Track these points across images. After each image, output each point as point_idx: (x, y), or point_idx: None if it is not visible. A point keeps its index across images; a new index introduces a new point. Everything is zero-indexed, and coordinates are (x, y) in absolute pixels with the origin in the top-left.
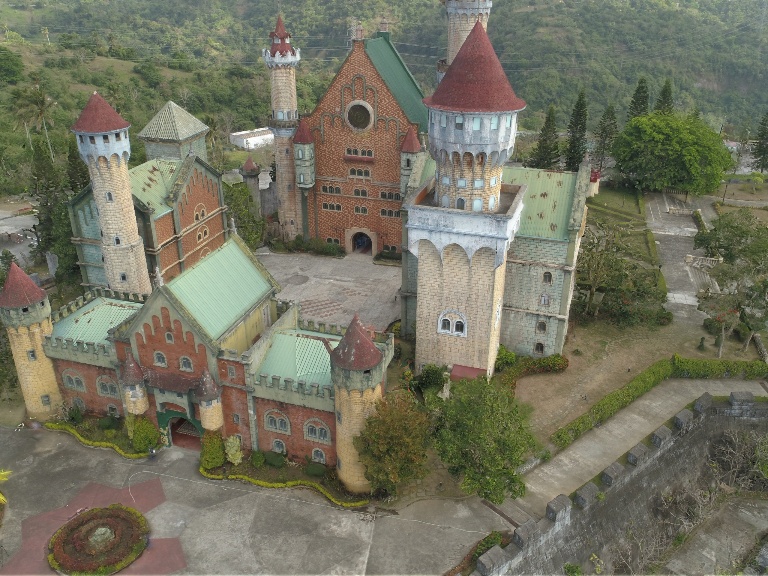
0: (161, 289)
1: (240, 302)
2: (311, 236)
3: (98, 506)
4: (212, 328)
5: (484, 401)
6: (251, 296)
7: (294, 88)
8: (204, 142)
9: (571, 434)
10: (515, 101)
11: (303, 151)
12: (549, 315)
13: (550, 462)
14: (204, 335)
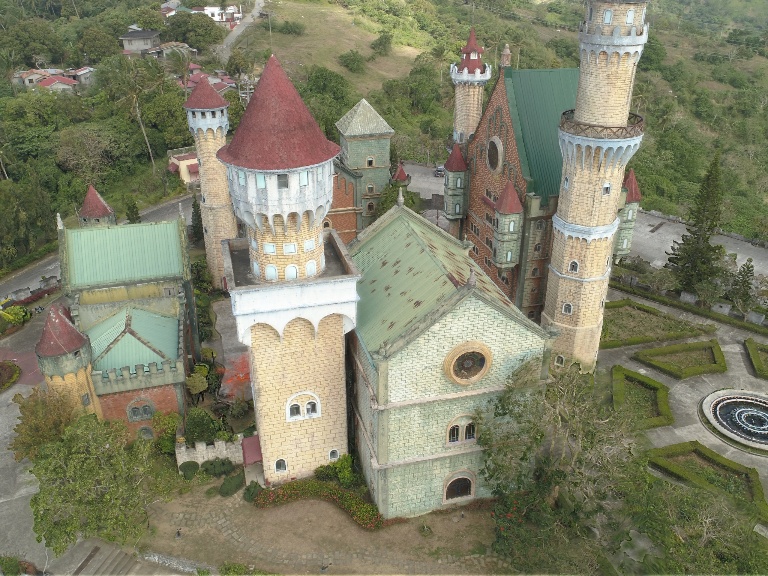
0: (58, 231)
1: (133, 271)
2: None
3: (21, 364)
4: (82, 277)
5: (76, 445)
6: (151, 271)
7: (474, 109)
8: (388, 144)
9: None
10: (282, 160)
11: (448, 178)
12: (371, 452)
13: None
14: (64, 278)
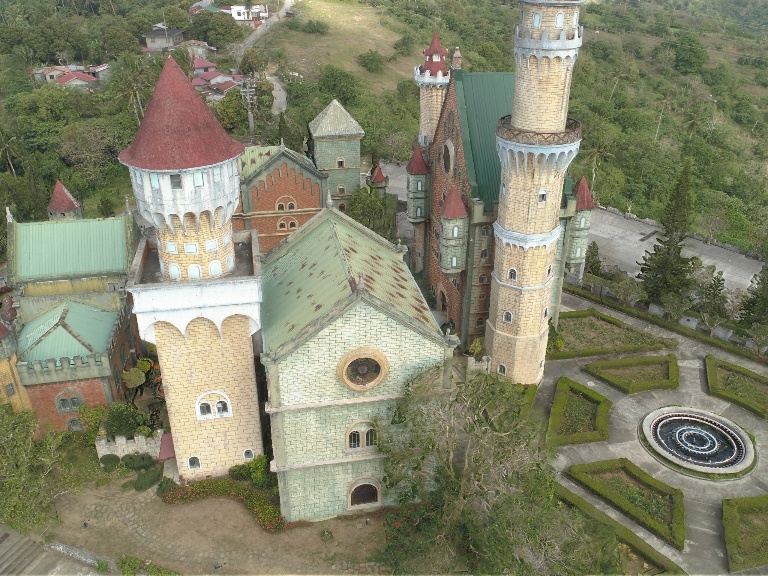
0: None
1: (78, 265)
2: (427, 276)
3: None
4: (28, 270)
5: None
6: (96, 266)
7: (438, 112)
8: None
9: (146, 575)
10: (175, 160)
11: (409, 181)
12: (274, 454)
13: (104, 575)
14: (10, 270)
